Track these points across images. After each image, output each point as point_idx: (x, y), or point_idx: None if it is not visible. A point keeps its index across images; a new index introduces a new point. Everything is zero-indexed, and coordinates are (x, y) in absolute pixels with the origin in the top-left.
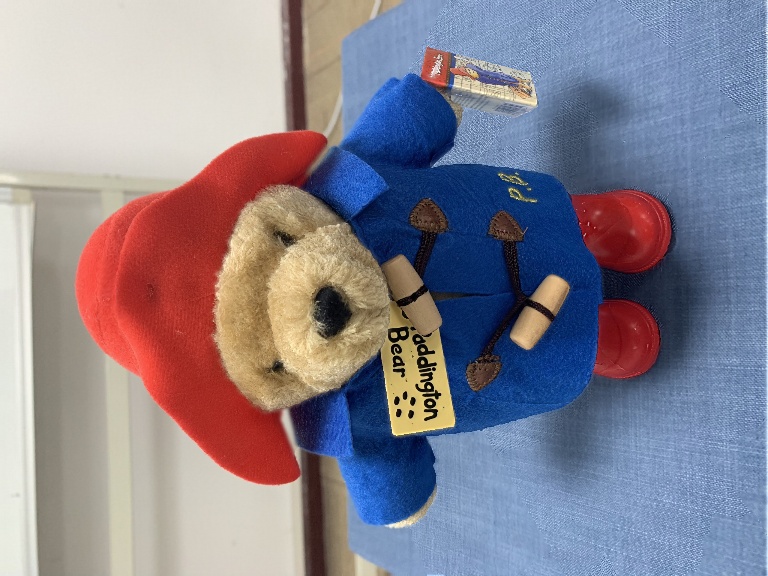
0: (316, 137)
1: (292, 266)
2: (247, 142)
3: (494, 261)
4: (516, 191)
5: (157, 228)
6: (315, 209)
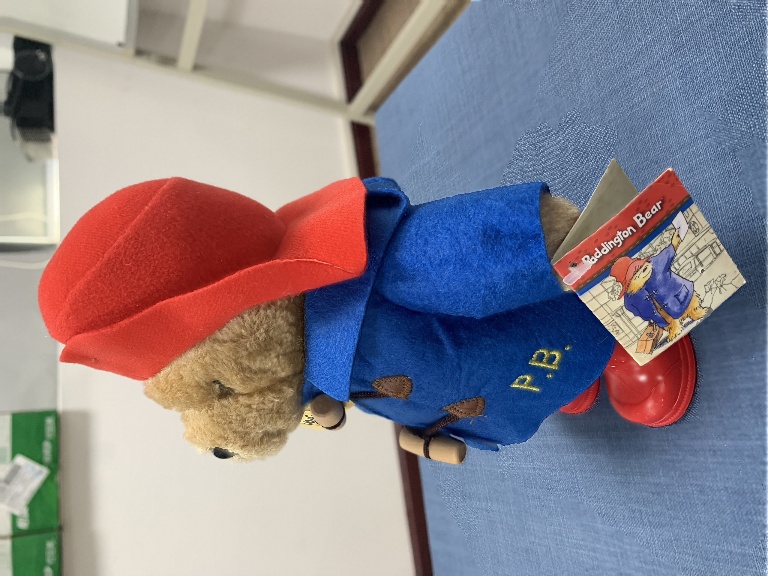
0: (345, 277)
1: (207, 424)
2: (246, 276)
3: (427, 418)
4: (528, 377)
5: (103, 346)
6: (275, 364)
